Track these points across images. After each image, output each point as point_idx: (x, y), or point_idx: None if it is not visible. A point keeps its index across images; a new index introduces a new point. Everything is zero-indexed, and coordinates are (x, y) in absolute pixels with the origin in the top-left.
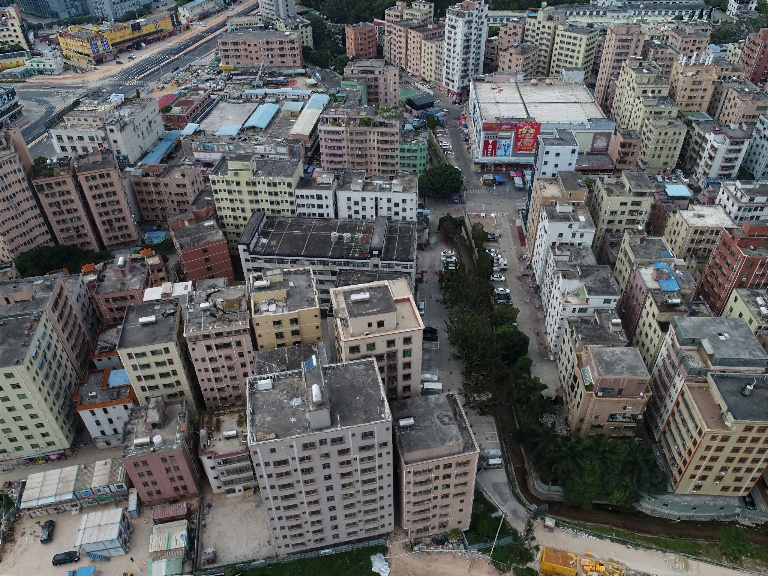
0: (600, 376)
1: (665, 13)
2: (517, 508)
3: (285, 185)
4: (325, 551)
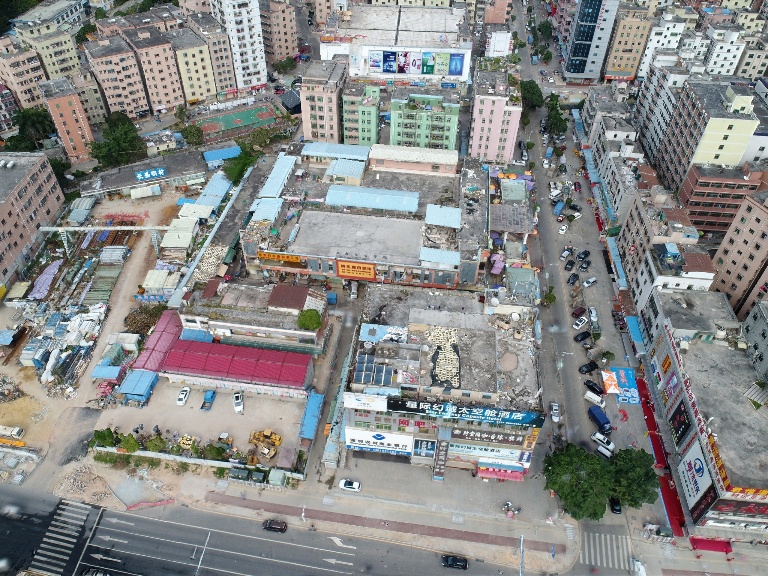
0: None
1: None
2: None
3: None
4: None
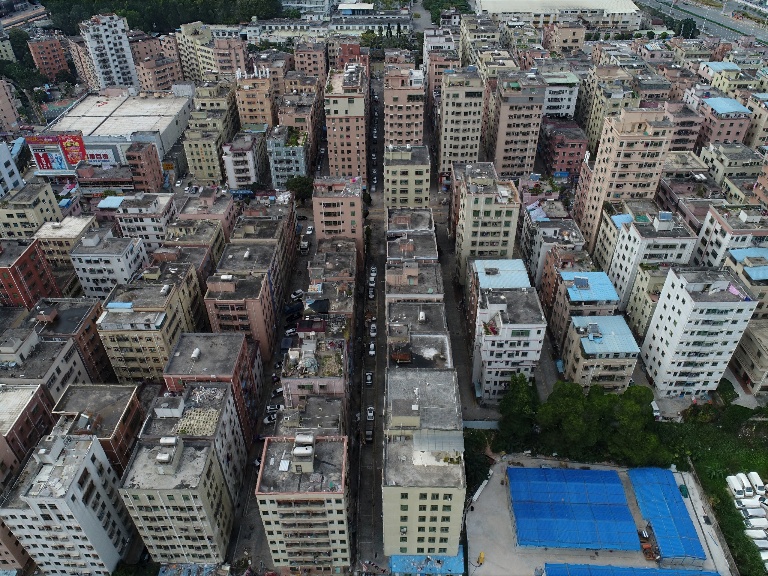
0: None
1: (366, 27)
2: None
3: None
4: None
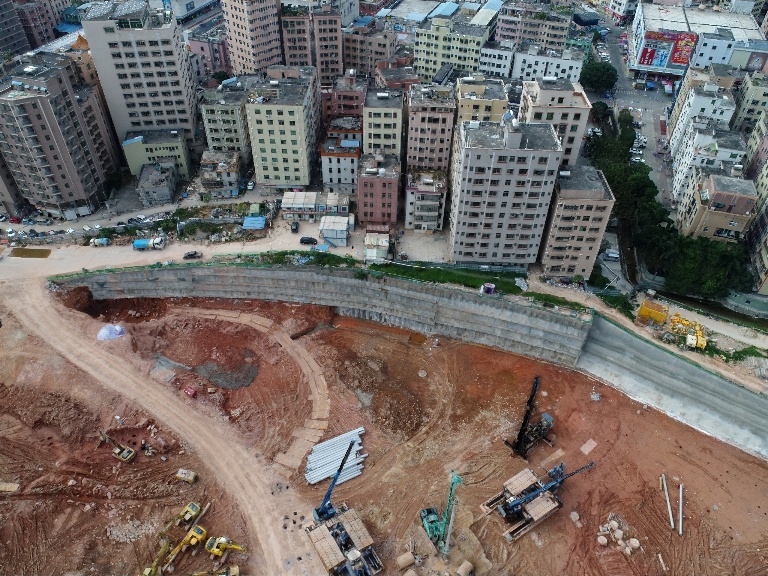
0: (716, 191)
1: None
2: (626, 284)
3: (475, 43)
4: (484, 267)
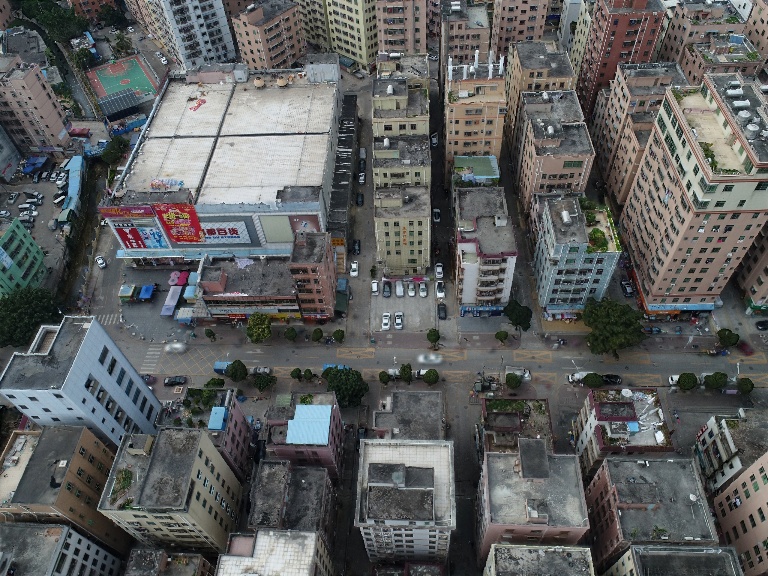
0: None
1: None
2: None
3: None
4: None
